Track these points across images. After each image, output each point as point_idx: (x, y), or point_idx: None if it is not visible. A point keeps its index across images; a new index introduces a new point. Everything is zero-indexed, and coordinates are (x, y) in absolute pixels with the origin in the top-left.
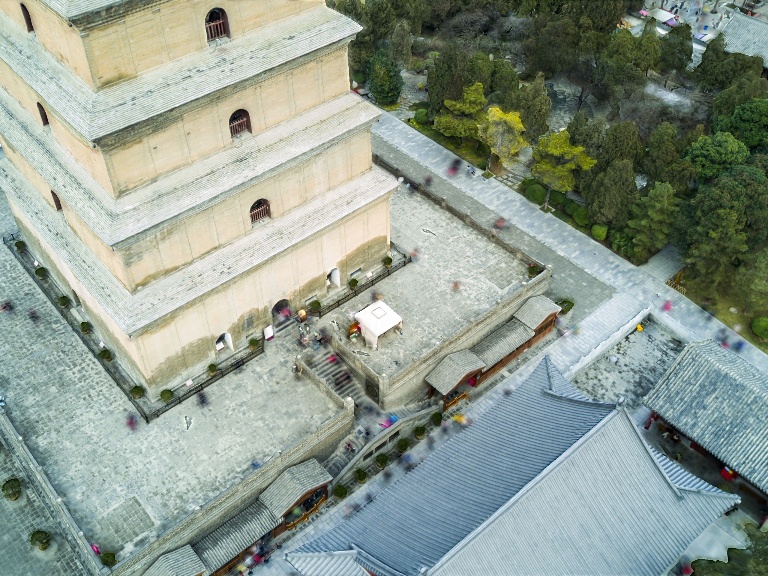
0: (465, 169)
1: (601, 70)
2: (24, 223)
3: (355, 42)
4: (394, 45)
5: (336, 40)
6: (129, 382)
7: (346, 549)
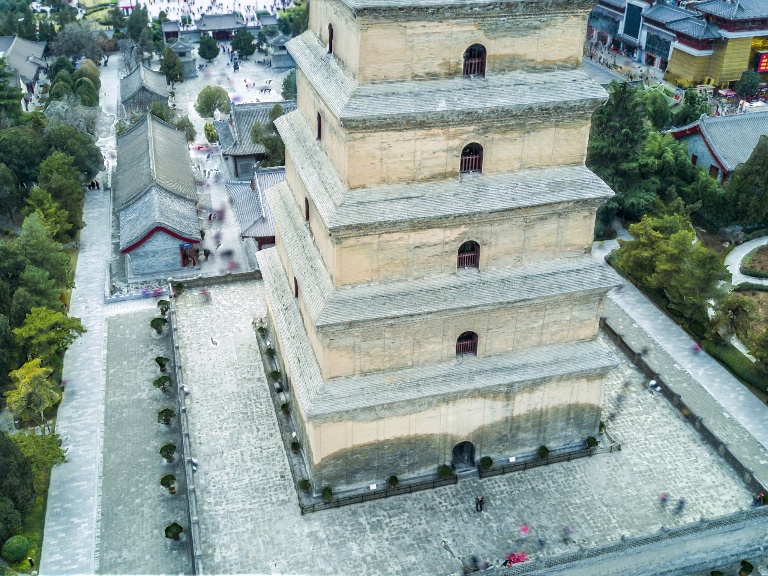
0: (67, 459)
1: None
2: None
3: None
4: None
5: None
6: None
7: None
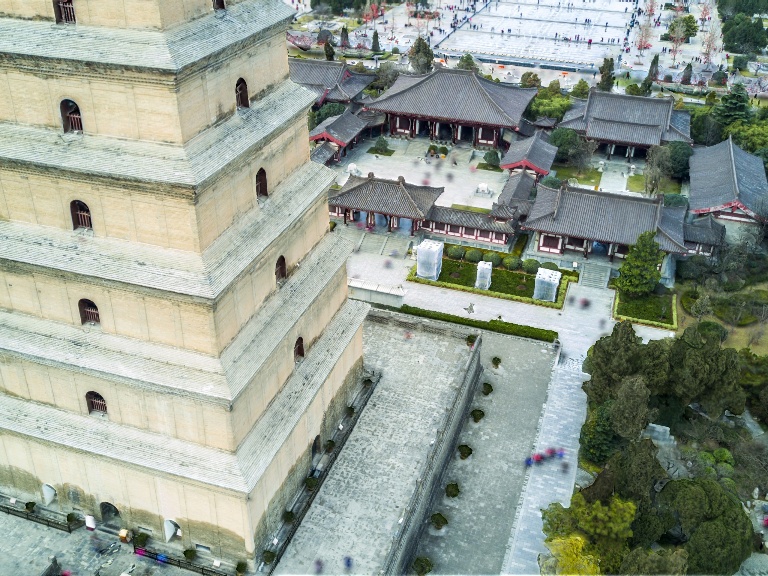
0: None
1: None
2: None
3: (605, 372)
4: None
5: (178, 291)
6: None
7: None
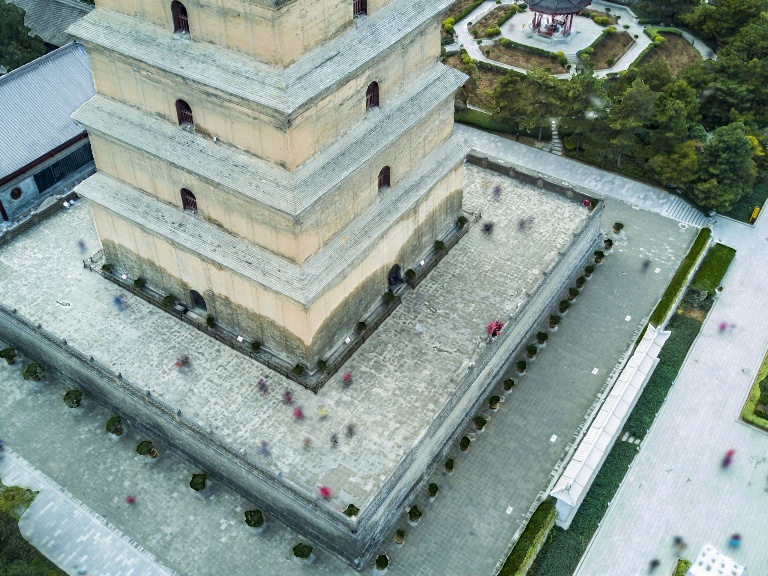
0: None
1: None
2: None
3: None
4: None
5: None
6: None
7: None
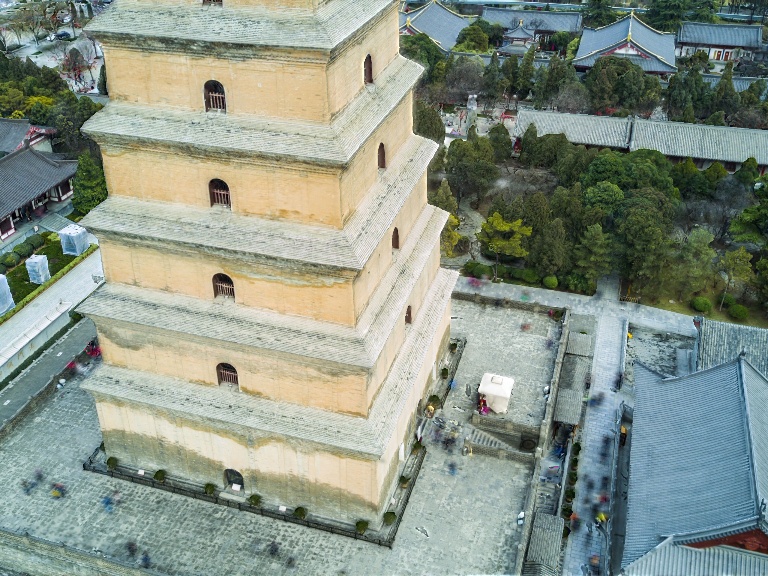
0: None
1: (459, 172)
2: (130, 430)
3: None
4: None
5: None
6: (339, 526)
7: (659, 542)
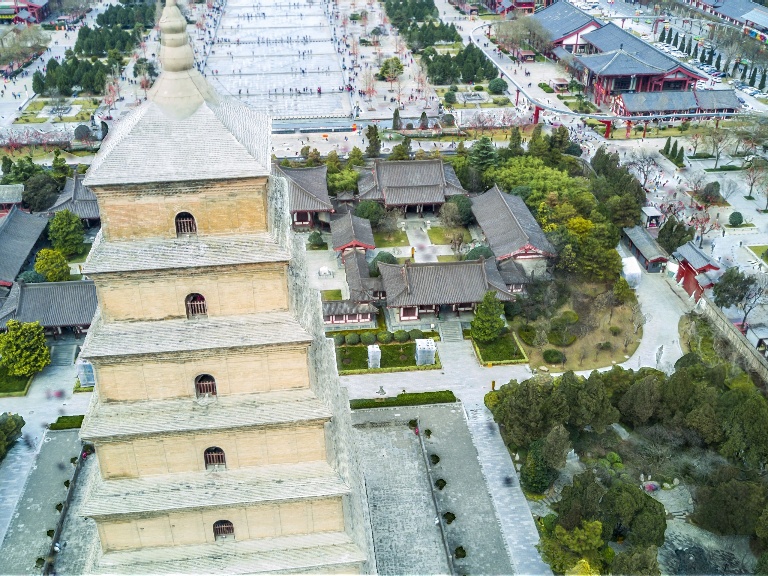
0: None
1: None
2: None
3: (523, 422)
4: (548, 443)
5: (320, 495)
6: None
7: None
